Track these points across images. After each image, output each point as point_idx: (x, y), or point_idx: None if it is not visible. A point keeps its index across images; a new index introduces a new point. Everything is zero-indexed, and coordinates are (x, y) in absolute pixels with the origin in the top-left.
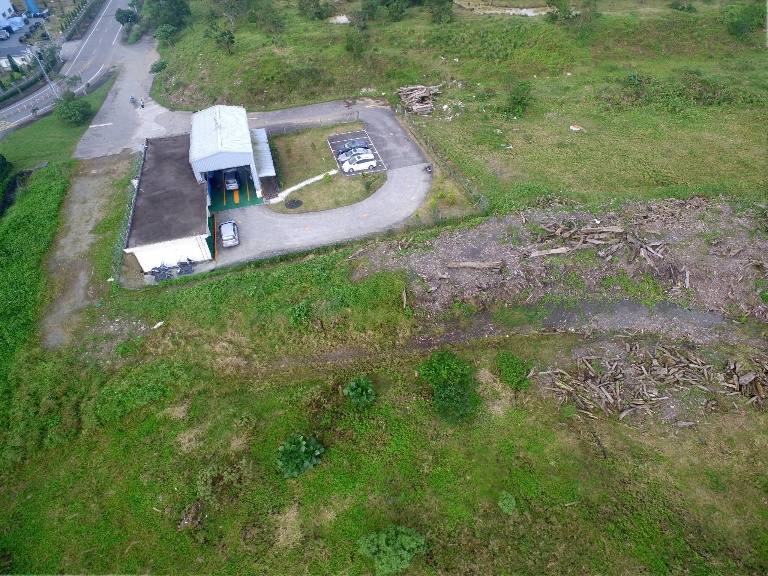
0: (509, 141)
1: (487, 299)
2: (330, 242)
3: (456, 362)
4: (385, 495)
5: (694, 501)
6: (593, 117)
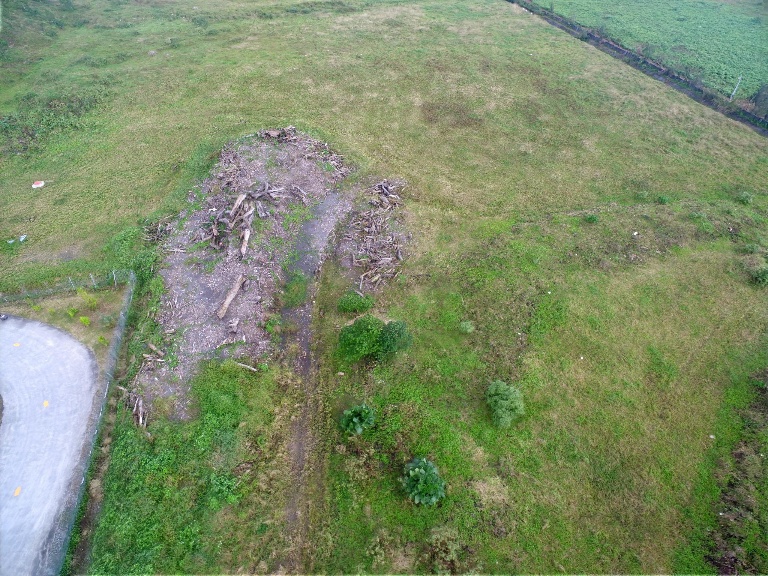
0: (9, 235)
1: (269, 304)
2: (79, 455)
3: (367, 318)
4: (461, 407)
5: (457, 250)
6: (31, 169)
